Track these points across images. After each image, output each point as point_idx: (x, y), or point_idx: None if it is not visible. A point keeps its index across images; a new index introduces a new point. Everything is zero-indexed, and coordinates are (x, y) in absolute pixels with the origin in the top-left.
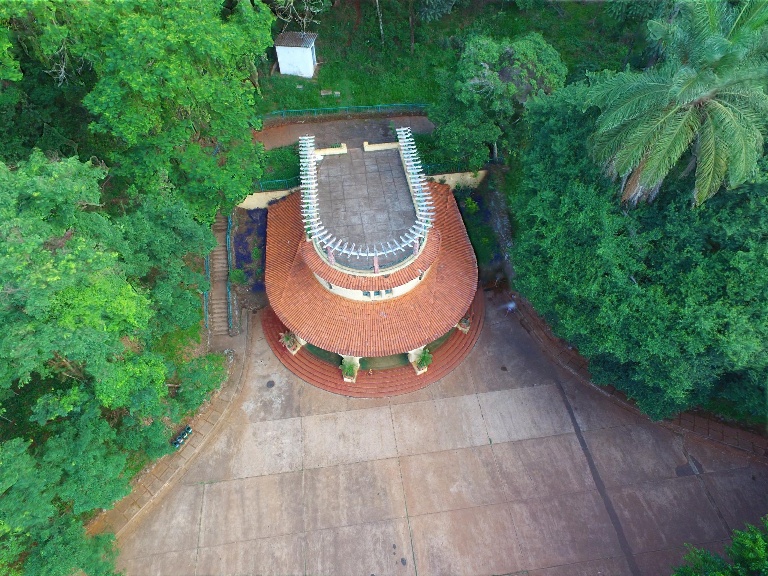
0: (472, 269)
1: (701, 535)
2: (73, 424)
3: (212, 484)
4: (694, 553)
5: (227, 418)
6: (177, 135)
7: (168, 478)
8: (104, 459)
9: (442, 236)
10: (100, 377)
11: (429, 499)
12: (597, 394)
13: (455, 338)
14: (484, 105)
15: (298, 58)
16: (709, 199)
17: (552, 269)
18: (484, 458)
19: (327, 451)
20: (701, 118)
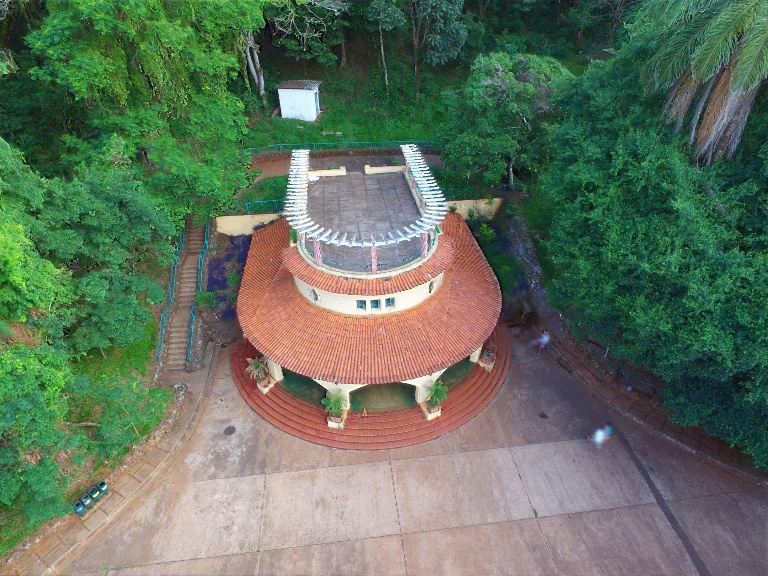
0: (494, 290)
1: None
2: None
3: (119, 570)
4: None
5: (162, 474)
6: (146, 116)
7: (56, 559)
8: None
9: (455, 255)
10: None
11: None
12: (677, 450)
13: (476, 376)
14: None
15: (300, 101)
16: None
17: (608, 245)
18: (528, 538)
19: (297, 523)
20: None
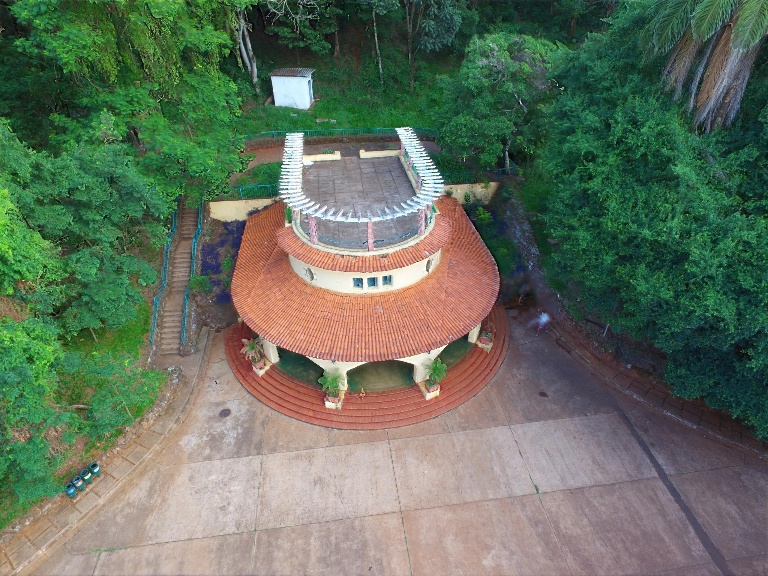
0: (491, 270)
1: None
2: None
3: (112, 552)
4: None
5: (156, 456)
6: (137, 94)
7: (46, 541)
8: None
9: (452, 236)
10: None
11: None
12: (678, 425)
13: (474, 356)
14: None
15: (294, 89)
16: None
17: (608, 214)
18: (530, 513)
19: (295, 502)
20: None
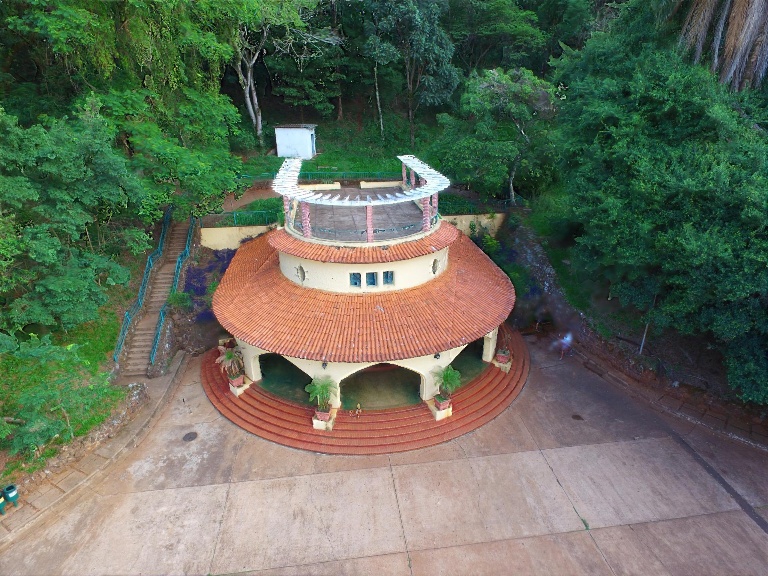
0: (504, 282)
1: None
2: None
3: None
4: None
5: (95, 484)
6: (132, 96)
7: None
8: None
9: (459, 253)
10: None
11: None
12: (750, 450)
13: (491, 375)
14: None
15: (297, 140)
16: None
17: (640, 174)
18: (581, 554)
19: (266, 540)
20: None
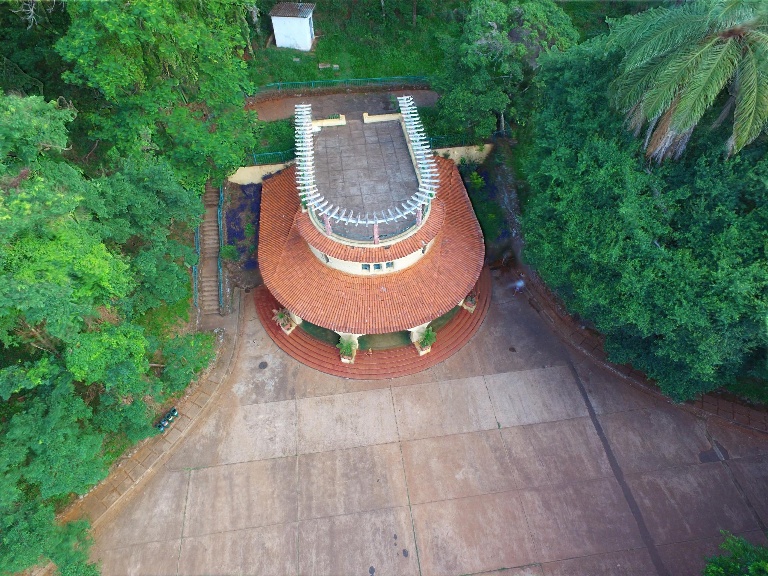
0: (478, 244)
1: (729, 525)
2: (43, 400)
3: (199, 470)
4: (732, 541)
5: (216, 400)
6: (162, 94)
7: (151, 463)
8: (77, 439)
9: (446, 210)
10: (63, 338)
11: (433, 486)
12: (612, 376)
13: (460, 317)
14: (491, 73)
15: (295, 29)
16: (744, 151)
17: (568, 234)
18: (492, 443)
19: (323, 435)
20: (741, 51)
